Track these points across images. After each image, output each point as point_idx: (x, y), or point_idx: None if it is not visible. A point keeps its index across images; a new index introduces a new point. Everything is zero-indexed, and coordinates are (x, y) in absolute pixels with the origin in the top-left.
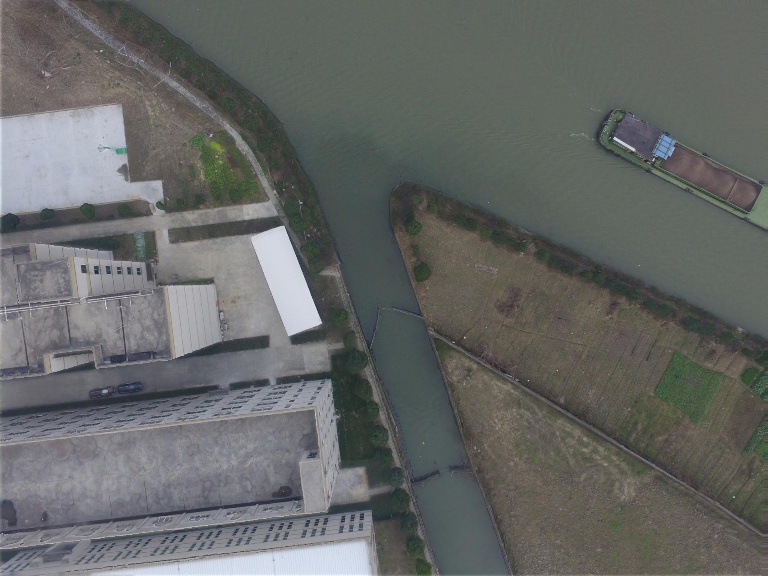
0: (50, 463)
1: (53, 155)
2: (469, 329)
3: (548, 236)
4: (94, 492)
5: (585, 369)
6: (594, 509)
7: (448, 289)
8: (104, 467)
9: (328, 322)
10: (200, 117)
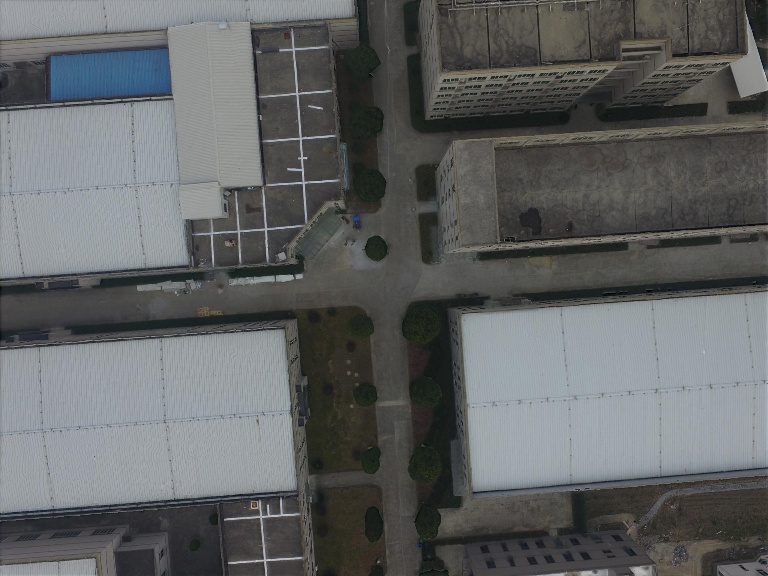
0: (579, 172)
1: None
2: None
3: None
4: (620, 204)
5: None
6: None
7: None
8: (632, 179)
9: (767, 92)
10: None
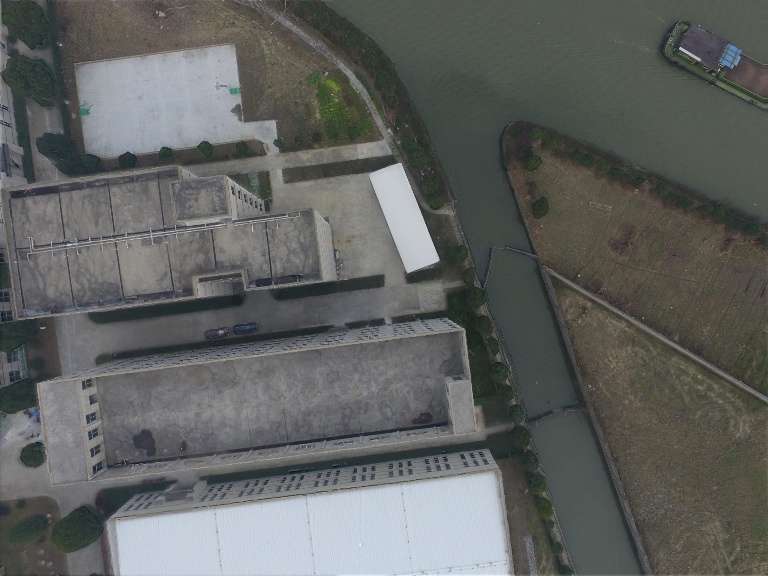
0: (189, 392)
1: (166, 96)
2: (583, 267)
3: (661, 173)
4: (233, 421)
5: (700, 306)
6: (710, 447)
7: (563, 227)
8: (243, 395)
9: (444, 260)
10: (314, 56)
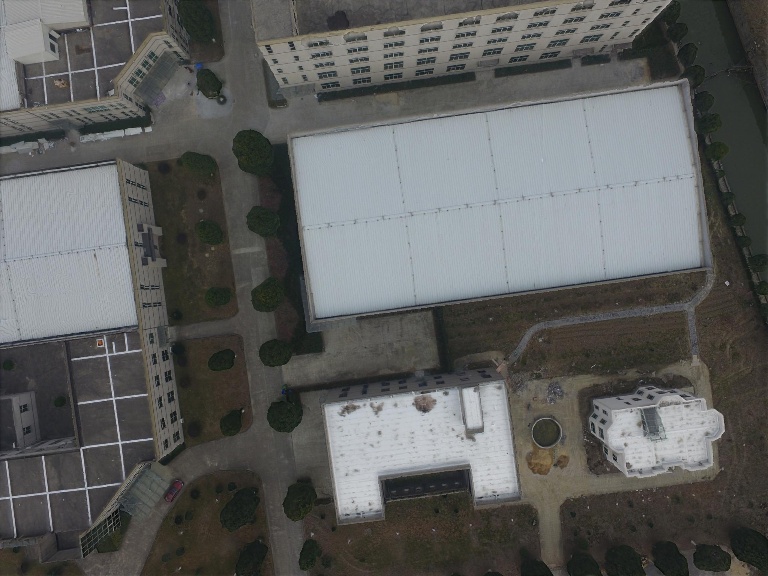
0: None
1: None
2: None
3: None
4: (428, 1)
5: None
6: None
7: None
8: None
9: None
10: None
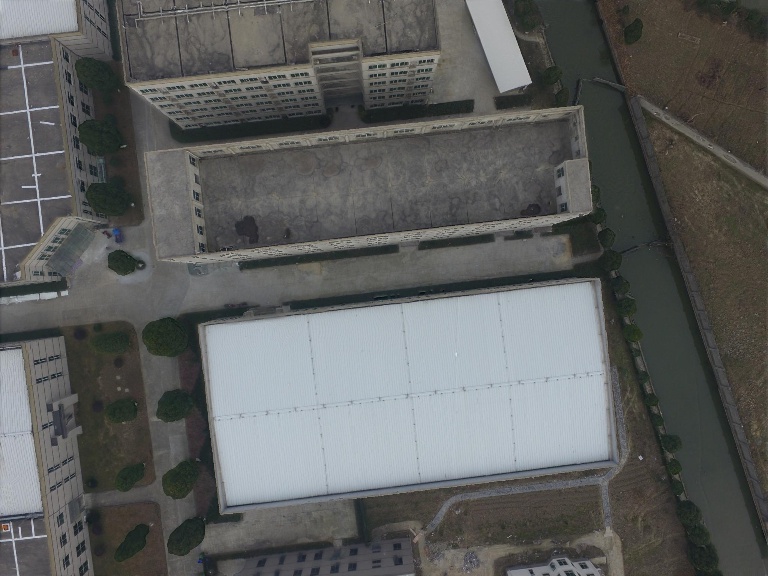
0: (294, 178)
1: None
2: (670, 100)
3: (749, 8)
4: (339, 208)
5: None
6: None
7: (652, 57)
8: (350, 182)
9: (534, 86)
10: None
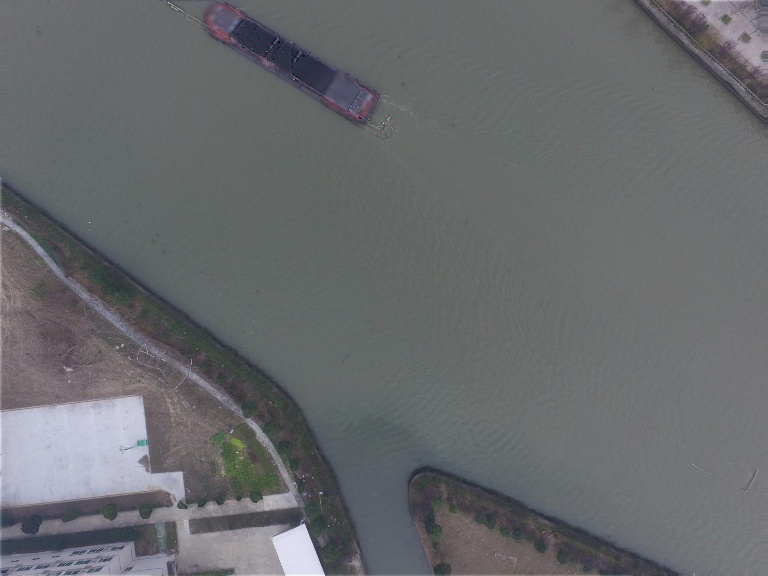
0: None
1: (74, 446)
2: None
3: (567, 524)
4: None
5: None
6: None
7: None
8: None
9: None
10: (221, 411)
